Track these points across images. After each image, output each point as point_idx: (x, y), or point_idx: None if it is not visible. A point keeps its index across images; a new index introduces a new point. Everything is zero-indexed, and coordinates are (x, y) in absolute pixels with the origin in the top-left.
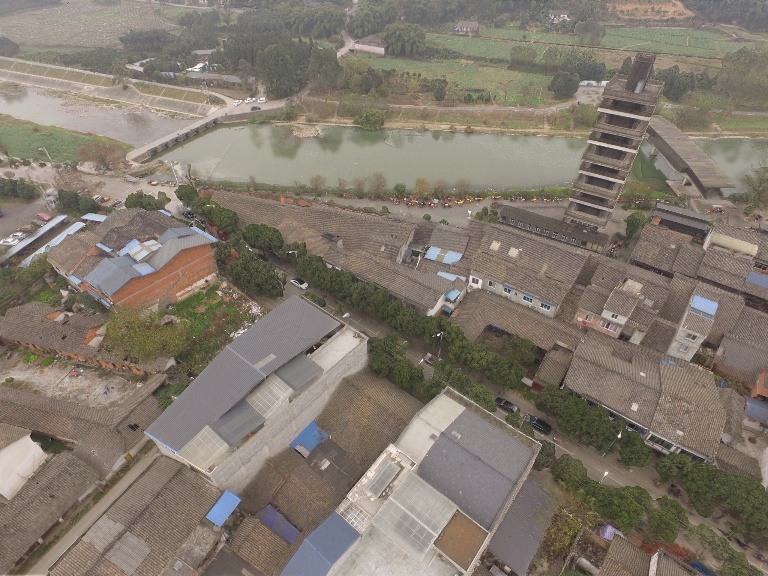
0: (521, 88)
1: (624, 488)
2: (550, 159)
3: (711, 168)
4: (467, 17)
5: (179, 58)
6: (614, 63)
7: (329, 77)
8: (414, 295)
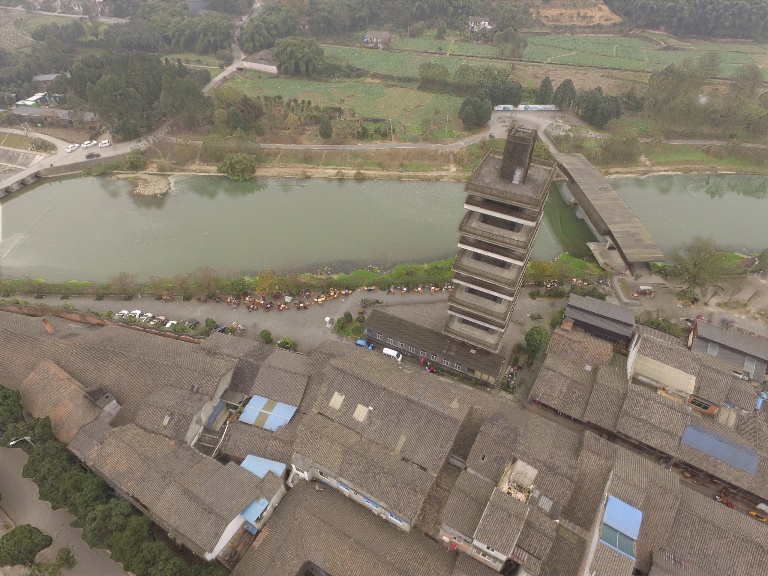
0: (421, 121)
1: None
2: (452, 215)
3: (637, 233)
4: (380, 25)
5: (11, 87)
6: (535, 80)
7: (187, 113)
8: (187, 524)
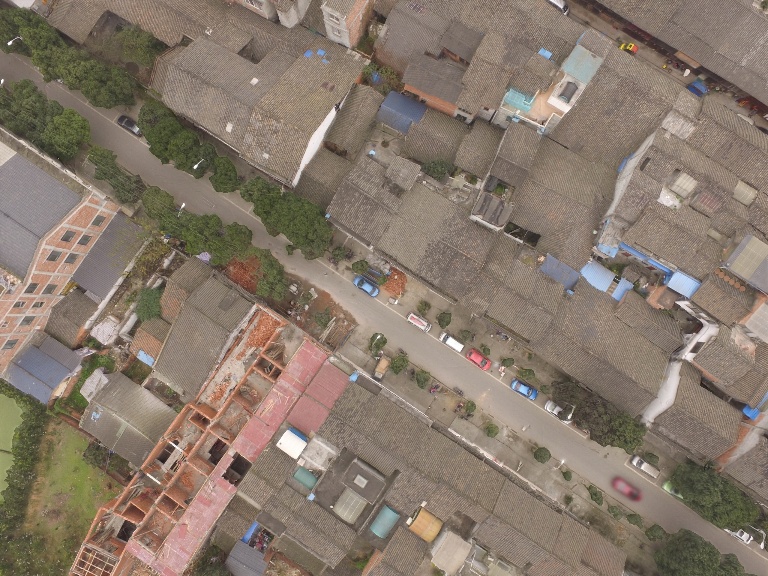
0: None
1: (194, 219)
2: None
3: None
4: None
5: None
6: None
7: None
8: None
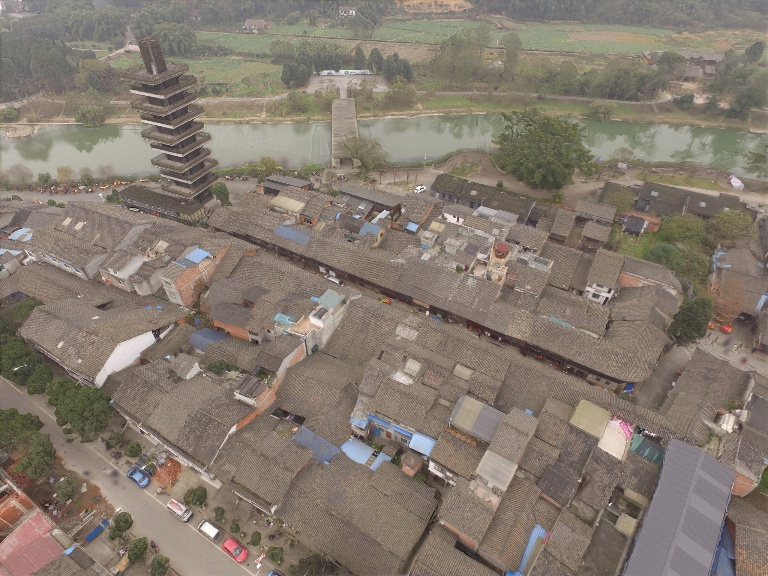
0: None
1: None
2: (245, 143)
3: None
4: (263, 16)
5: None
6: None
7: (52, 77)
8: None
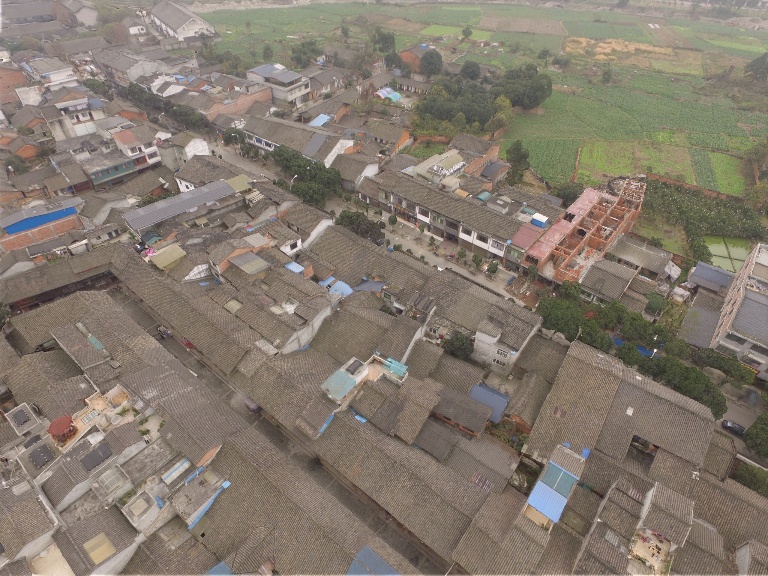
0: None
1: None
2: None
3: None
4: None
5: None
6: None
7: None
8: None
